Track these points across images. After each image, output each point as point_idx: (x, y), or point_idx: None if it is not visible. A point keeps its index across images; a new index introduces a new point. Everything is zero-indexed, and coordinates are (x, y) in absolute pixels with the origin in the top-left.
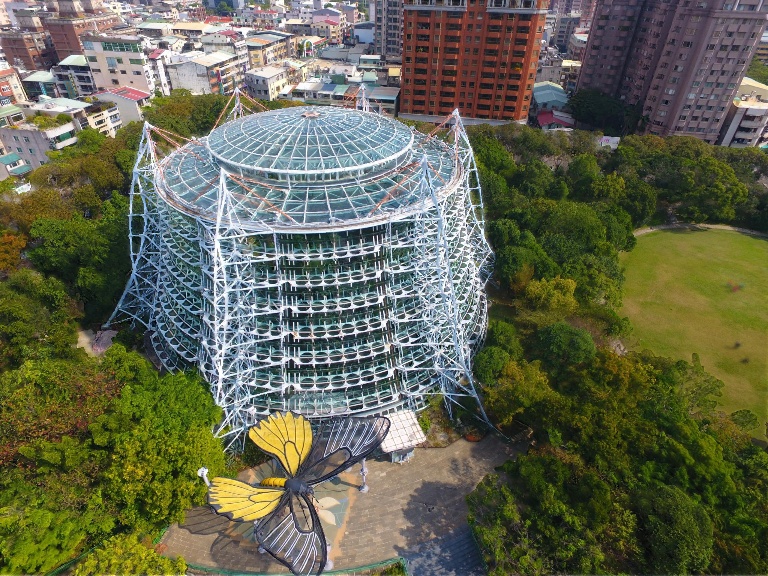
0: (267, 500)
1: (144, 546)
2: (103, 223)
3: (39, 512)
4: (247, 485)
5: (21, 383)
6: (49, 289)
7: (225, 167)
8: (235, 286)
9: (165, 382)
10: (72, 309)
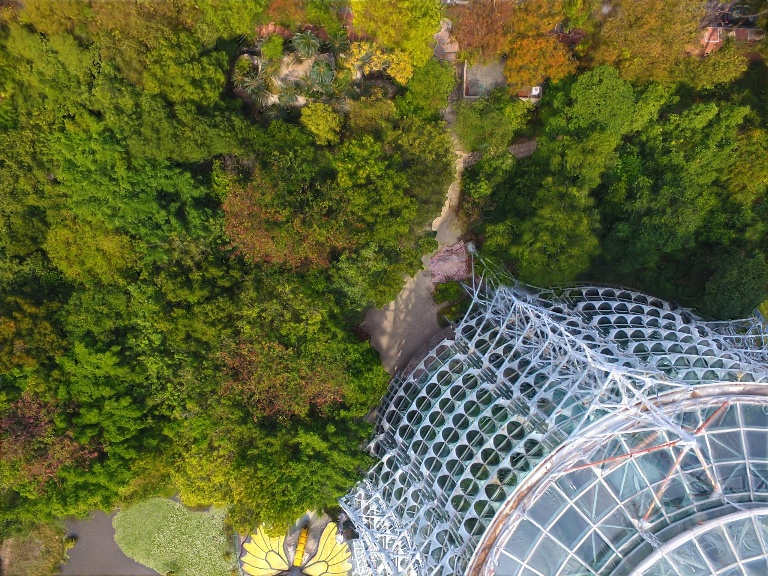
0: (272, 565)
1: (224, 476)
2: (662, 129)
3: (201, 422)
4: (283, 539)
5: (303, 319)
6: (495, 162)
7: (623, 573)
8: (419, 574)
9: (341, 455)
10: (467, 217)
